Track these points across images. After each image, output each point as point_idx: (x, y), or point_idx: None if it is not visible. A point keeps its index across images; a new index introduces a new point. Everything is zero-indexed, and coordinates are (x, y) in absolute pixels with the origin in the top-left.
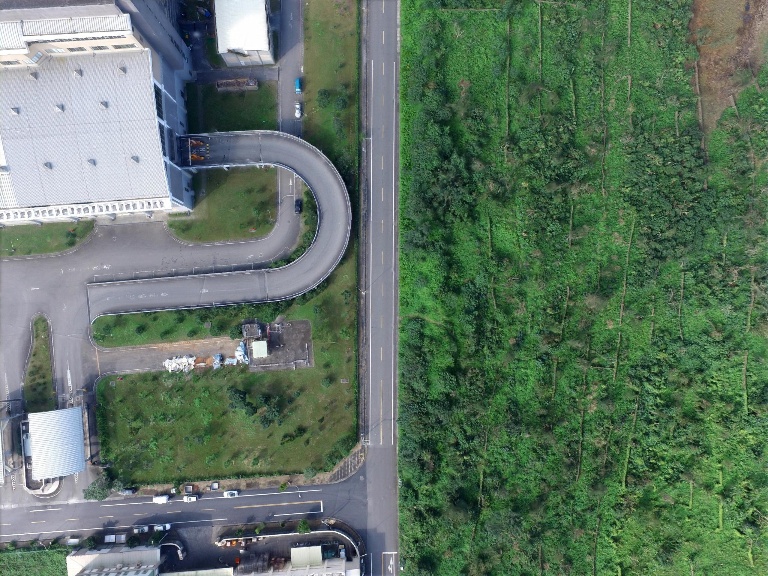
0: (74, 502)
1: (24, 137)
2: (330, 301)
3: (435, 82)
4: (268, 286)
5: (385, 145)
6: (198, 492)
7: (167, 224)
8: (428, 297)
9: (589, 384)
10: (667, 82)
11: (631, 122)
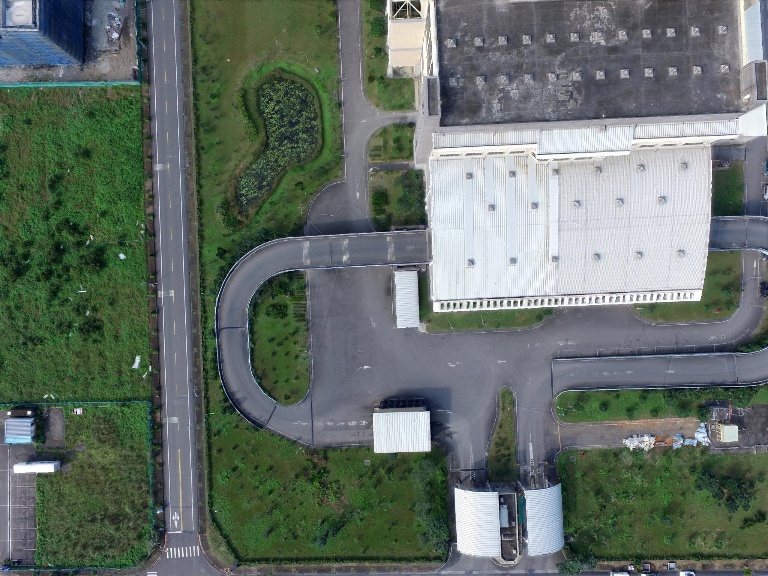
0: (532, 572)
1: (579, 229)
2: None
3: None
4: (738, 370)
5: None
6: (654, 570)
7: None
8: None
9: None
10: None
11: None
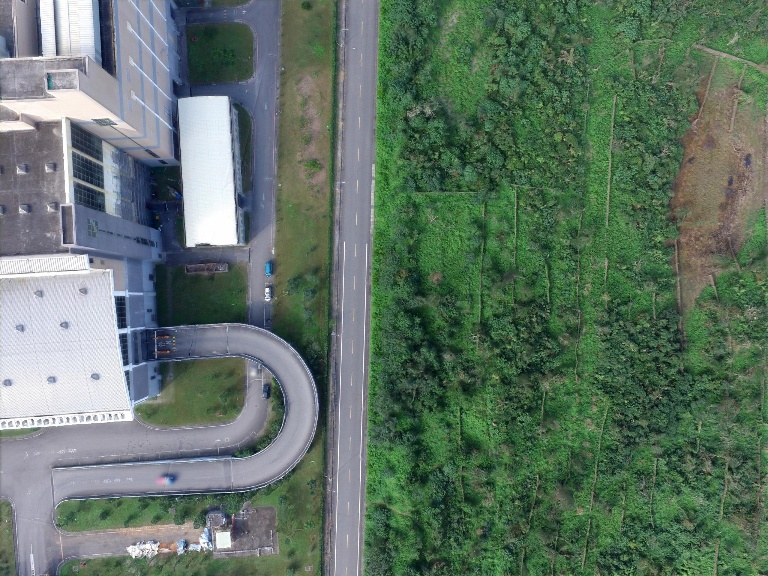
0: None
1: None
2: (296, 487)
3: (407, 268)
4: (233, 475)
5: (356, 329)
6: None
7: (133, 408)
8: (395, 488)
9: (557, 572)
10: (645, 262)
11: (607, 307)
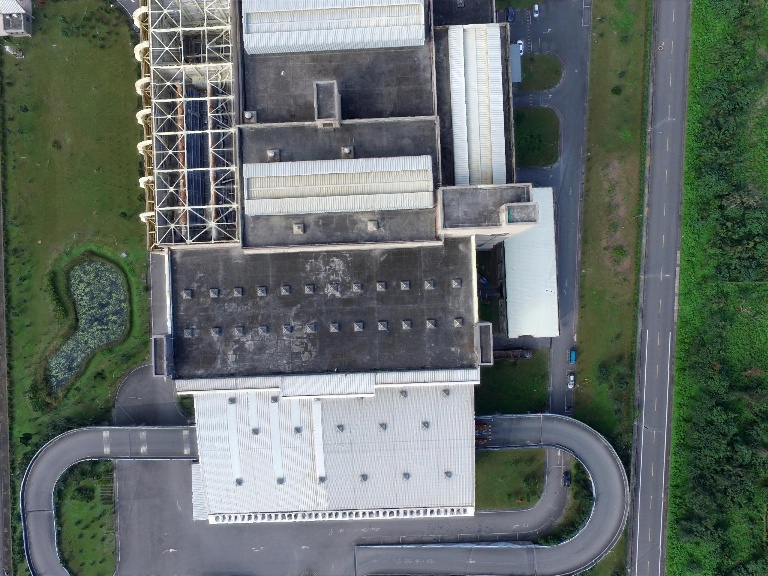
0: None
1: (345, 451)
2: None
3: (718, 360)
4: (537, 563)
5: (657, 418)
6: None
7: None
8: None
9: None
10: None
11: None
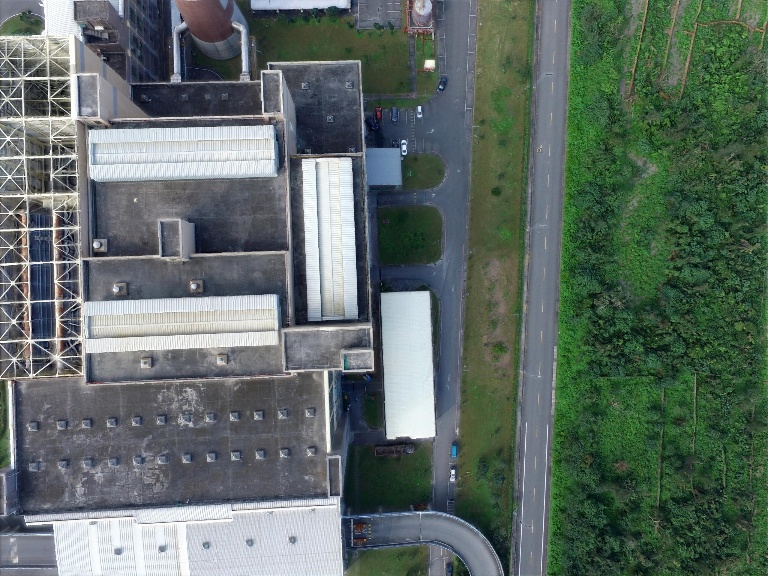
0: None
1: (211, 568)
2: None
3: (590, 453)
4: None
5: (536, 508)
6: None
7: None
8: None
9: None
10: None
11: None
